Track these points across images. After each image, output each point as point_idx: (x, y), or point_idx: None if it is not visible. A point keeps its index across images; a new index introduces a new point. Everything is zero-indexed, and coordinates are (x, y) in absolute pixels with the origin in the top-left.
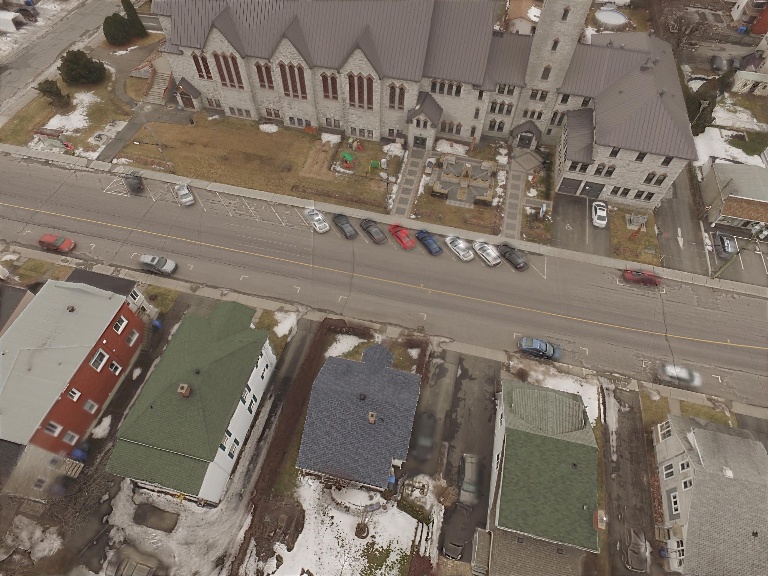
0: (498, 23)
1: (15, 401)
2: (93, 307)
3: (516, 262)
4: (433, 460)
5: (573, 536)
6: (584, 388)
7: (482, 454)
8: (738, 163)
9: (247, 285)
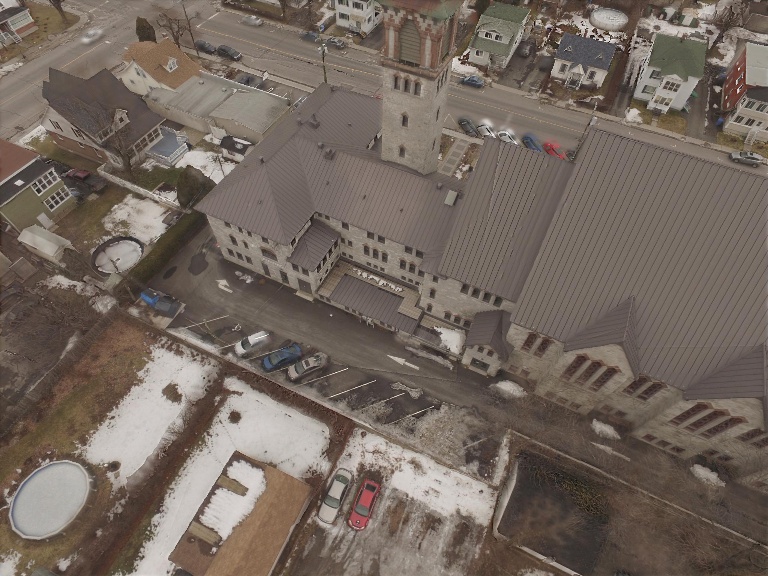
0: (308, 547)
1: (767, 54)
2: (763, 80)
3: (466, 125)
4: (542, 59)
5: (502, 4)
6: (454, 67)
7: (517, 57)
8: (230, 139)
9: (669, 141)
